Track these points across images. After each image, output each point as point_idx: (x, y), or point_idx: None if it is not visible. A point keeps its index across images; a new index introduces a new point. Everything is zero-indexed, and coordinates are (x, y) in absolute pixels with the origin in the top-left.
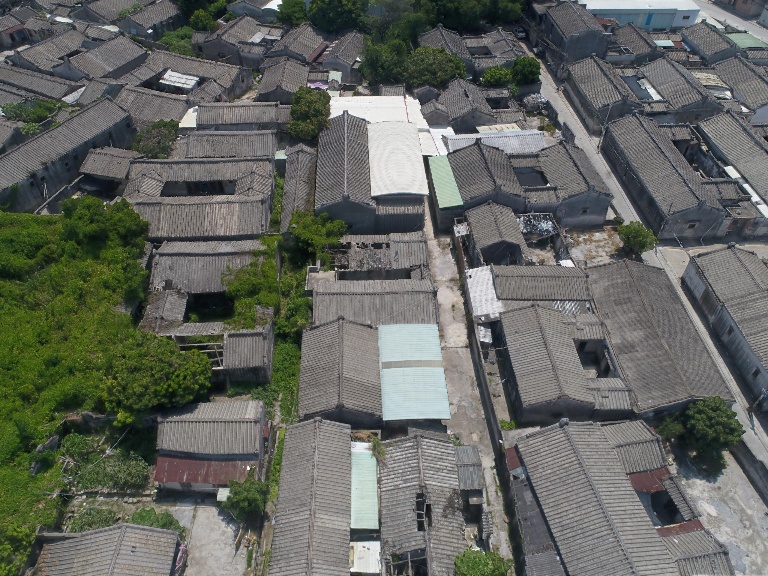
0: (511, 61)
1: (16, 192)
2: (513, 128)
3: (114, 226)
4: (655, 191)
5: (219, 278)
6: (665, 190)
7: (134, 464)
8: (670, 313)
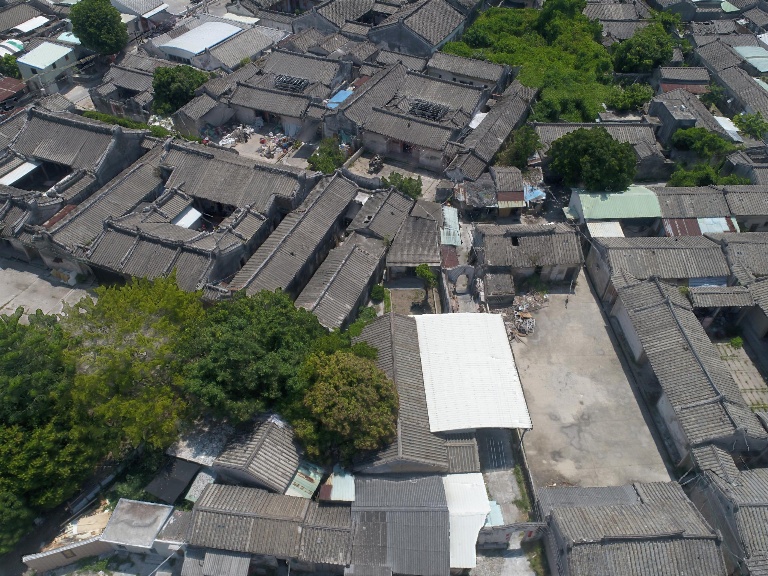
0: None
1: (481, 3)
2: None
3: (577, 4)
4: None
5: (634, 32)
6: None
7: (649, 87)
8: None
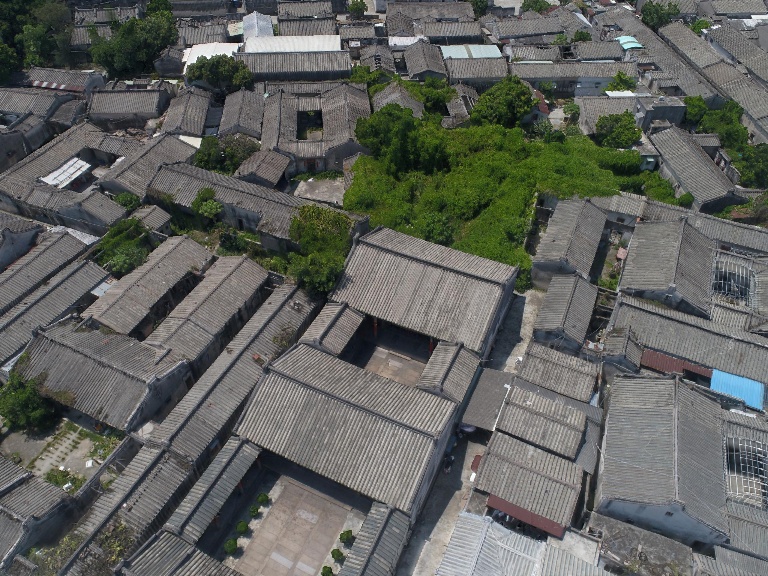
0: (138, 13)
1: None
2: (237, 24)
3: None
4: None
5: (416, 102)
6: None
7: None
8: (420, 3)
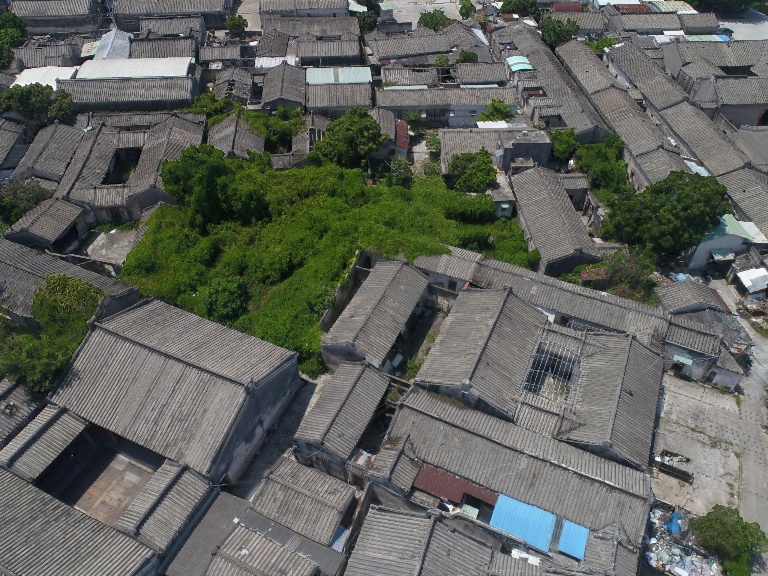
0: None
1: None
2: (93, 44)
3: None
4: (200, 9)
5: (255, 136)
6: (202, 5)
7: None
8: None
